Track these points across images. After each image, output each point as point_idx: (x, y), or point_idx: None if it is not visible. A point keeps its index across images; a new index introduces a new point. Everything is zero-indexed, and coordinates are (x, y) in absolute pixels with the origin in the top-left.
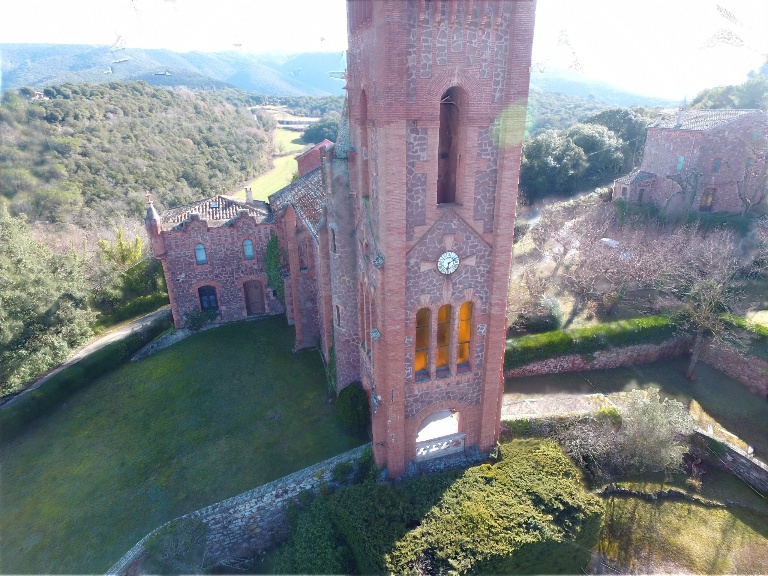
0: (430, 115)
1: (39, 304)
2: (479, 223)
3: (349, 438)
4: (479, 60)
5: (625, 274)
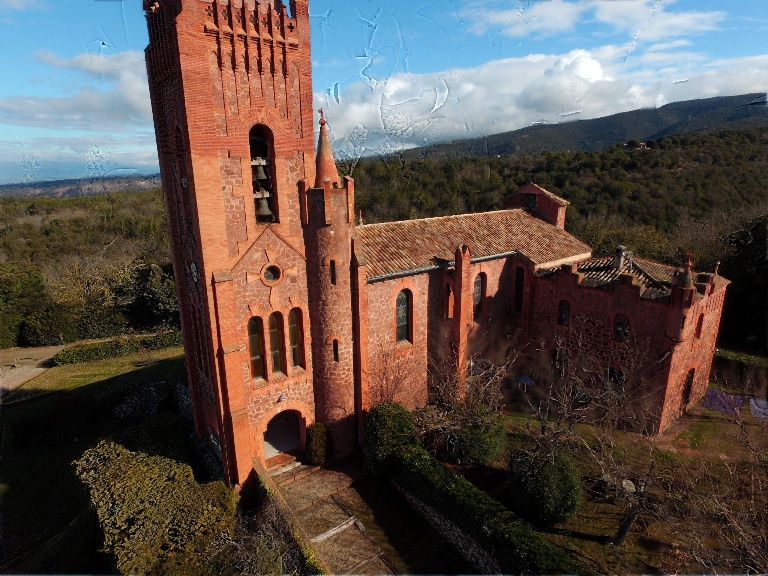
0: None
1: None
2: None
3: None
4: None
5: None
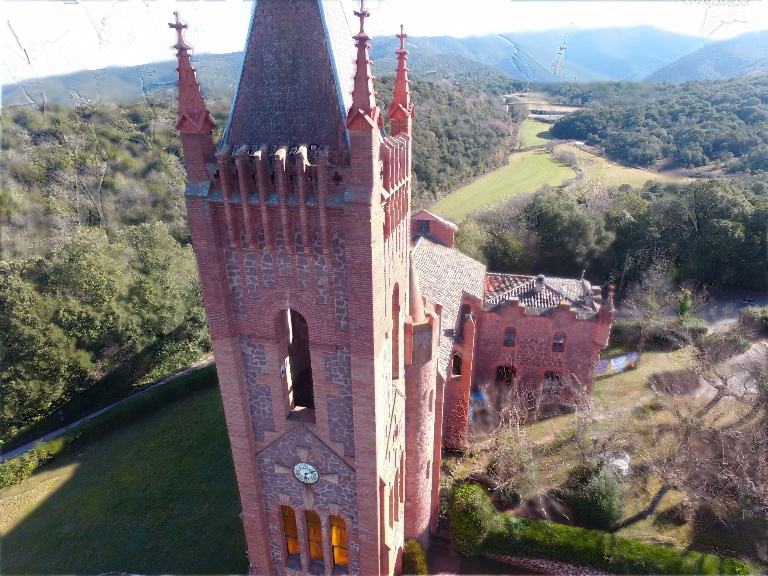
0: (265, 333)
1: (164, 328)
2: (338, 445)
3: None
4: (314, 286)
5: (762, 481)
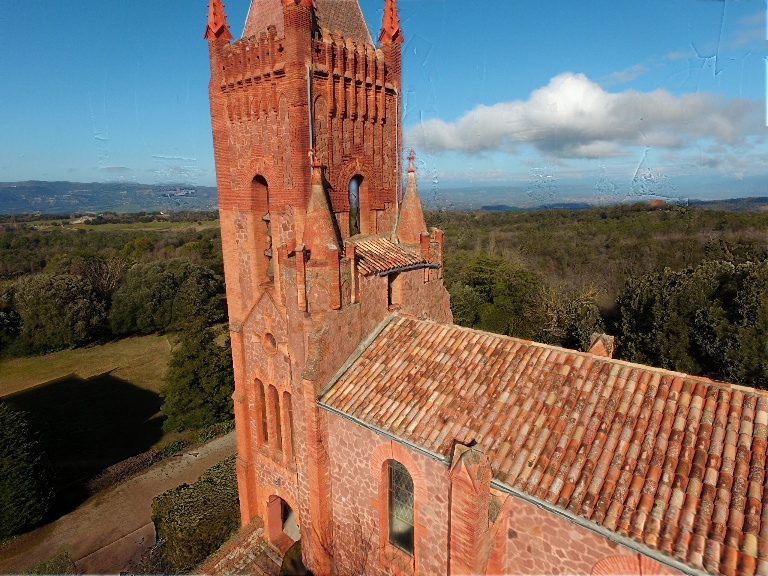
0: None
1: None
2: None
3: None
4: None
5: None
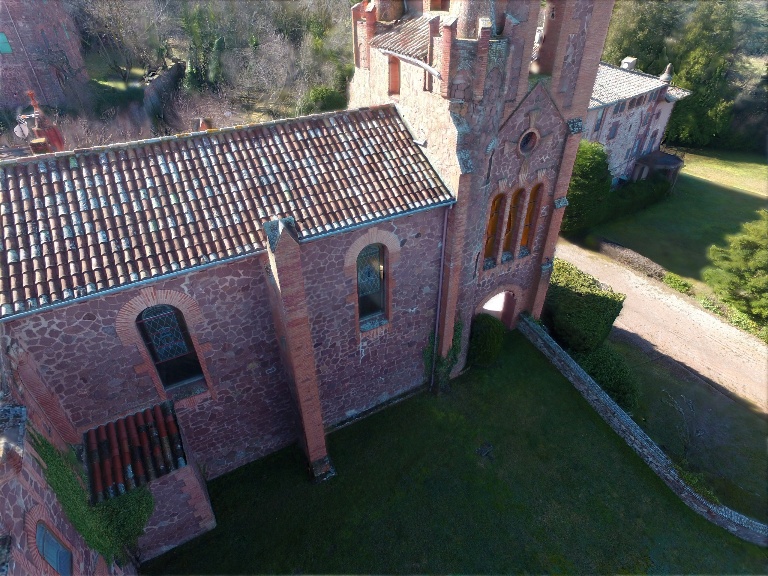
0: None
1: None
2: None
3: (502, 356)
4: None
5: None
